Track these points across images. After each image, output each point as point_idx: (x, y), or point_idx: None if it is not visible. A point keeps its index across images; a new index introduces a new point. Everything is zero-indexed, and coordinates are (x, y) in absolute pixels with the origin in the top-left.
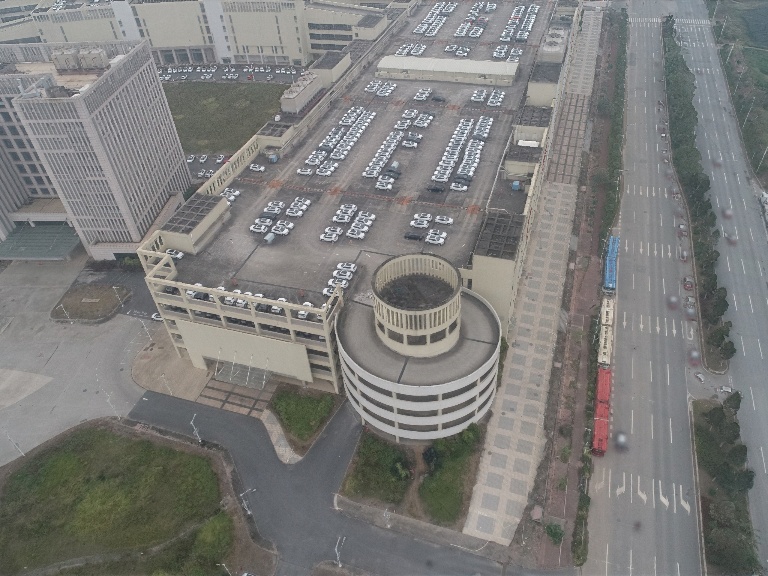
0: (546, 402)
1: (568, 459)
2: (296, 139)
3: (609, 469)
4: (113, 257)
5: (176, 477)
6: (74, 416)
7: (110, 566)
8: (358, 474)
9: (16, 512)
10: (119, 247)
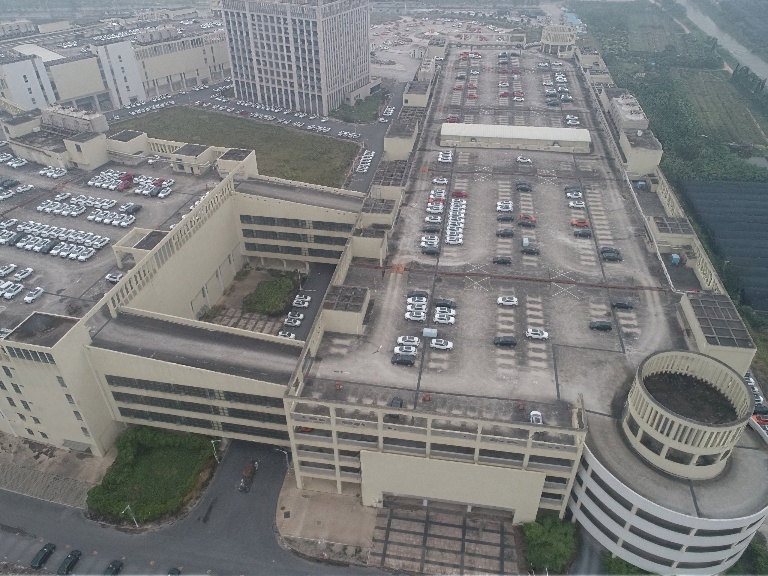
0: None
1: None
2: None
3: None
4: None
5: None
6: None
7: None
8: None
9: None
10: None
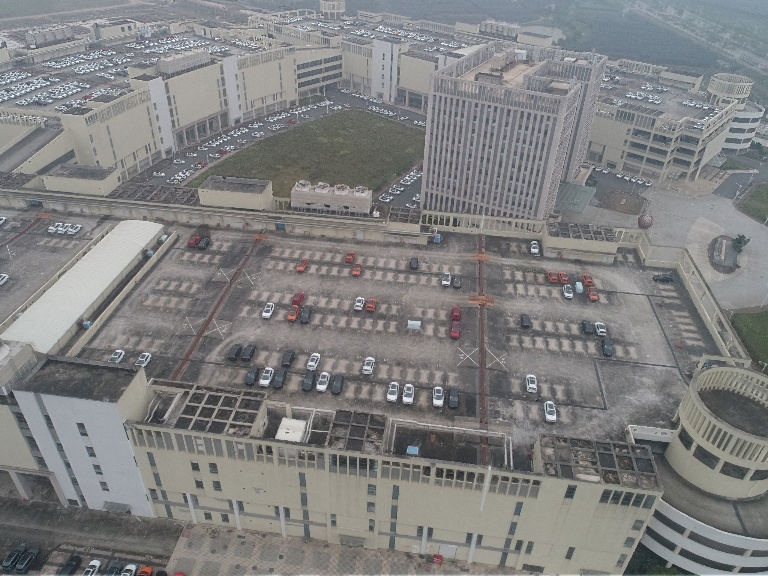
0: None
1: None
2: None
3: None
4: (584, 185)
5: None
6: None
7: None
8: (766, 160)
9: None
10: (588, 173)
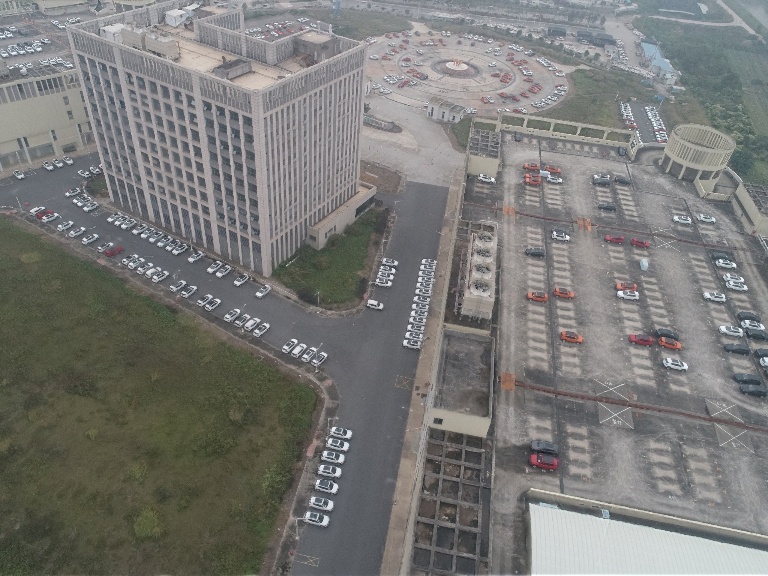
0: None
1: None
2: None
3: None
4: None
5: None
6: None
7: None
8: None
9: None
10: None
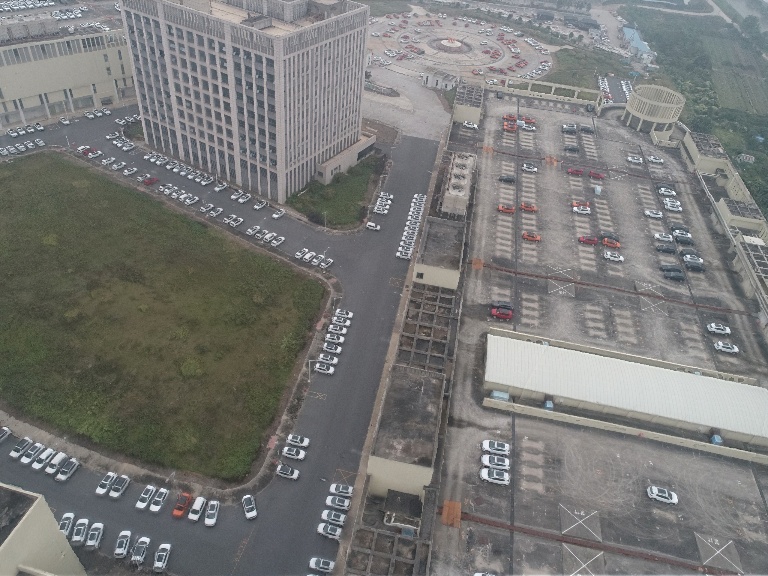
0: None
1: None
2: None
3: None
4: None
5: None
6: None
7: None
8: None
9: None
10: None
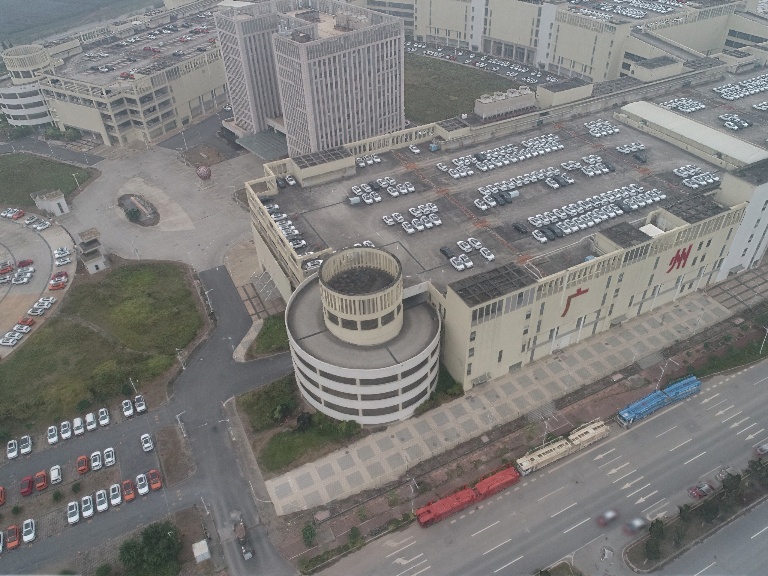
0: (435, 455)
1: (395, 506)
2: (470, 140)
3: (415, 540)
4: None
5: (178, 321)
6: (179, 255)
7: (103, 341)
8: (256, 395)
9: (104, 285)
10: None
